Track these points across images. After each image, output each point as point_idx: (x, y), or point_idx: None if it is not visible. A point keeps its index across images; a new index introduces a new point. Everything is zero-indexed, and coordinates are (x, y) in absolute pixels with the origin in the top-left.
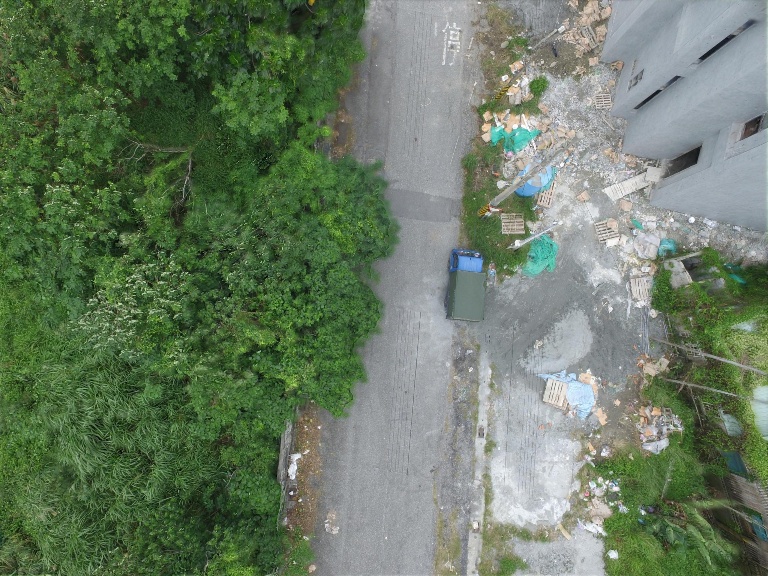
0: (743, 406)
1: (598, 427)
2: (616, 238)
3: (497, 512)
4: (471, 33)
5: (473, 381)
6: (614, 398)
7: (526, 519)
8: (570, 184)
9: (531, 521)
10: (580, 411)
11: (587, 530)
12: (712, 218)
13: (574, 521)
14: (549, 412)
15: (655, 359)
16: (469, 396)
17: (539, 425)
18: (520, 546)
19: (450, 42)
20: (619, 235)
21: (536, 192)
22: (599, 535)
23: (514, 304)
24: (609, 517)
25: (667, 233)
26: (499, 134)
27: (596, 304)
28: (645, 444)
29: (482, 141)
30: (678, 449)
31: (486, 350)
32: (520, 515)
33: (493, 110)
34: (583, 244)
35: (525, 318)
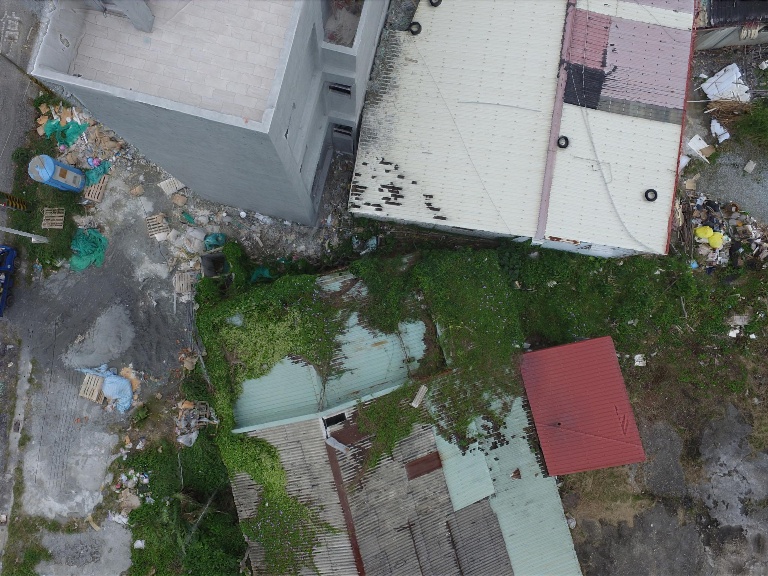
0: (216, 400)
1: (137, 420)
2: (163, 233)
3: (26, 505)
4: (31, 23)
5: (12, 376)
6: (156, 392)
7: (56, 511)
8: (125, 178)
9: (61, 513)
10: (119, 405)
11: (116, 521)
12: (262, 213)
13: (104, 513)
14: (87, 406)
15: (197, 353)
16: (6, 391)
17: (75, 419)
18: (48, 538)
19: (8, 32)
20: (170, 230)
21: (82, 186)
22: (128, 526)
23: (59, 299)
24: (136, 508)
25: (220, 228)
26: (52, 127)
27: (143, 299)
28: (179, 437)
29: (37, 134)
30: (204, 441)
31: (28, 345)
32: (51, 508)
33: (48, 102)
34: (135, 239)
35: (69, 313)
